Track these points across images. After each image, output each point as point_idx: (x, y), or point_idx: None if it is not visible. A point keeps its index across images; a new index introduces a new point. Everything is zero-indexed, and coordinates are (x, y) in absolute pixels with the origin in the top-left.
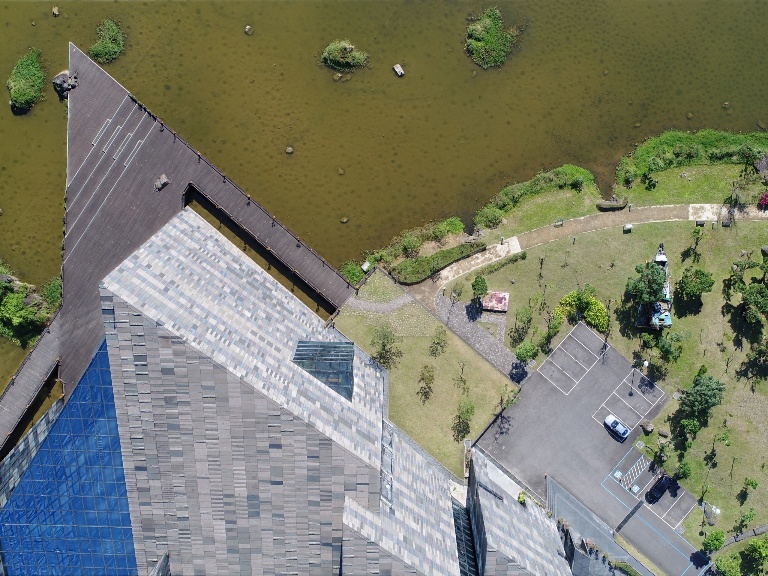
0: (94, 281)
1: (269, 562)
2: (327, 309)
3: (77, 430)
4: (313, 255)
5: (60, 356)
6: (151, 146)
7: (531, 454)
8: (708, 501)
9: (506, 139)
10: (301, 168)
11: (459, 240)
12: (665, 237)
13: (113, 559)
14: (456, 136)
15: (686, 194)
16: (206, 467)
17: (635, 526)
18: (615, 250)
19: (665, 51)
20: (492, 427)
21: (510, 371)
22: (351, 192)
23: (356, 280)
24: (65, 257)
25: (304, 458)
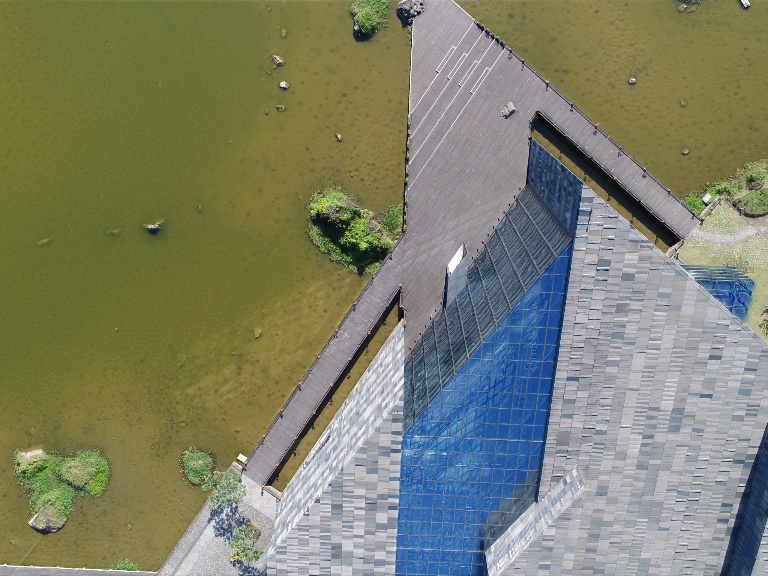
0: (438, 208)
1: (675, 479)
2: (666, 241)
3: (513, 339)
4: (659, 185)
5: (402, 283)
6: (499, 73)
7: None
8: None
9: None
10: (643, 99)
11: None
12: None
13: (513, 475)
14: None
15: None
16: (639, 378)
17: None
18: None
19: None
20: None
21: None
22: (693, 124)
23: (697, 212)
24: (409, 183)
25: (741, 370)
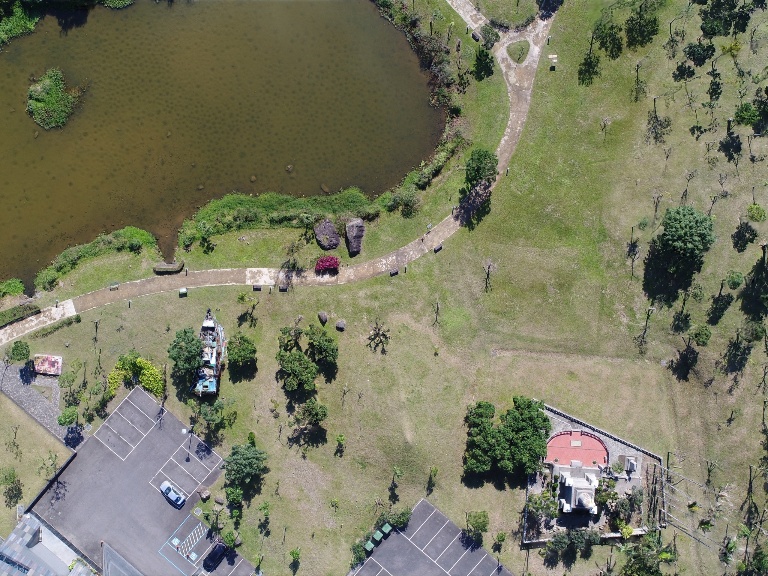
0: None
1: None
2: None
3: None
4: None
5: None
6: None
7: (87, 520)
8: (264, 570)
9: (68, 200)
10: None
11: (14, 302)
12: (222, 301)
13: None
14: (18, 197)
15: (244, 258)
16: None
17: None
18: (171, 314)
19: (228, 113)
20: (48, 492)
21: (66, 436)
22: None
23: None
24: None
25: None
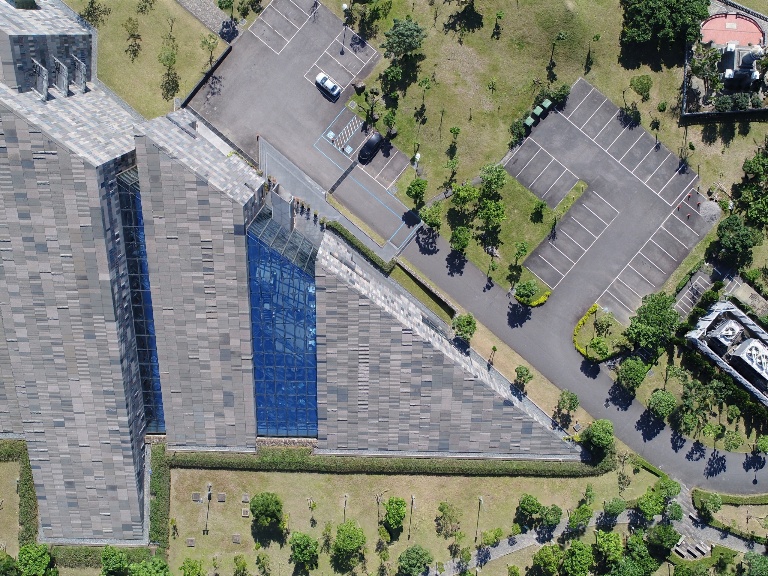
0: None
1: None
2: None
3: None
4: None
5: None
6: None
7: (243, 115)
8: (420, 159)
9: None
10: None
11: None
12: None
13: None
14: None
15: None
16: None
17: (348, 187)
18: None
19: None
20: (203, 87)
21: (221, 30)
22: None
23: None
24: None
25: None
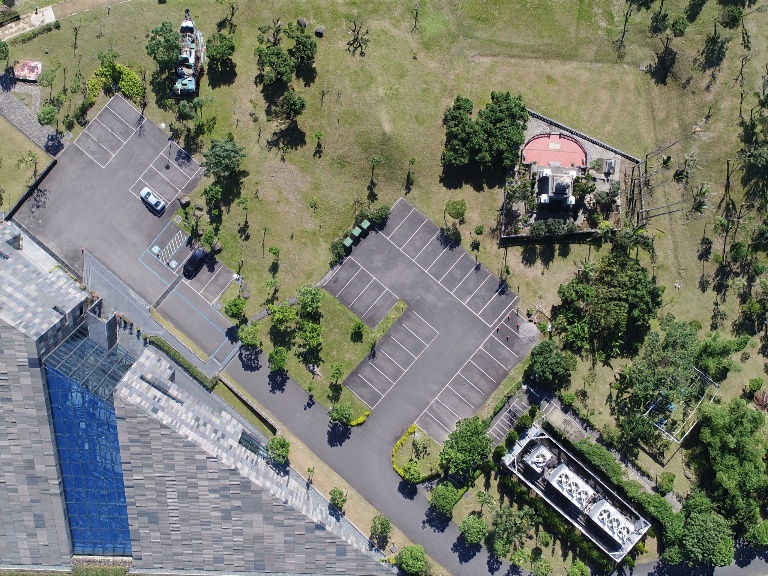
0: None
1: None
2: None
3: None
4: None
5: None
6: None
7: (68, 228)
8: (244, 275)
9: None
10: None
11: None
12: (201, 8)
13: None
14: None
15: None
16: None
17: (173, 302)
18: (150, 20)
19: None
20: (28, 200)
21: (46, 143)
22: None
23: None
24: None
25: None
